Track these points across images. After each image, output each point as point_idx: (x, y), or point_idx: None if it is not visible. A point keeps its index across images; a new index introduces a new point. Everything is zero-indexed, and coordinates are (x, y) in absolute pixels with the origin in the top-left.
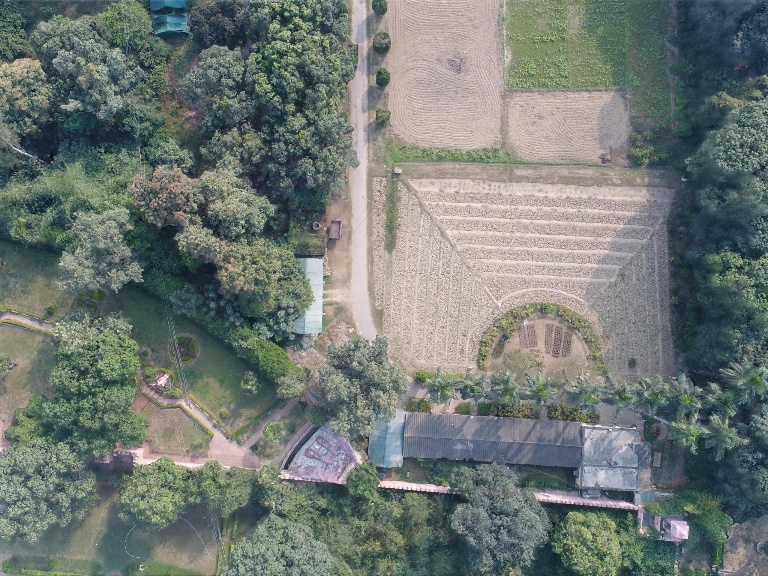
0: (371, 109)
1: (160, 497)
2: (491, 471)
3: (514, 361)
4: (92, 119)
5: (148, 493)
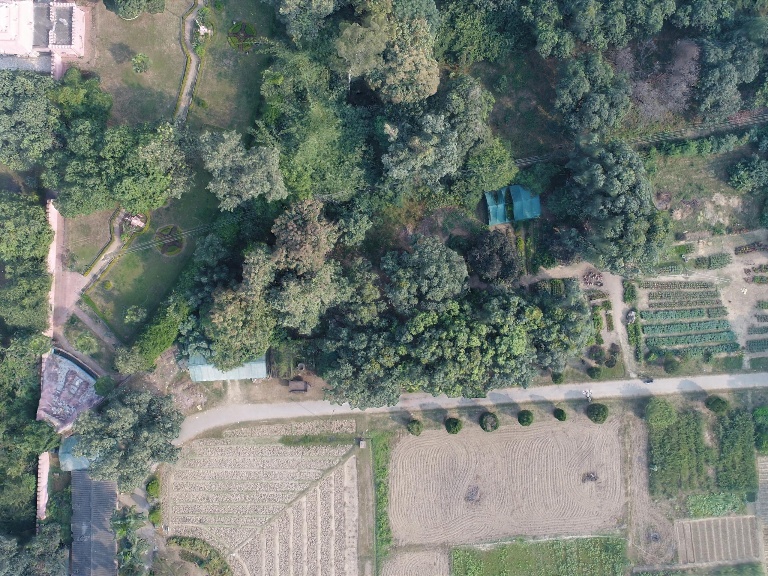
0: (424, 412)
1: (6, 241)
2: (53, 569)
3: (178, 572)
4: (388, 143)
5: (7, 230)
